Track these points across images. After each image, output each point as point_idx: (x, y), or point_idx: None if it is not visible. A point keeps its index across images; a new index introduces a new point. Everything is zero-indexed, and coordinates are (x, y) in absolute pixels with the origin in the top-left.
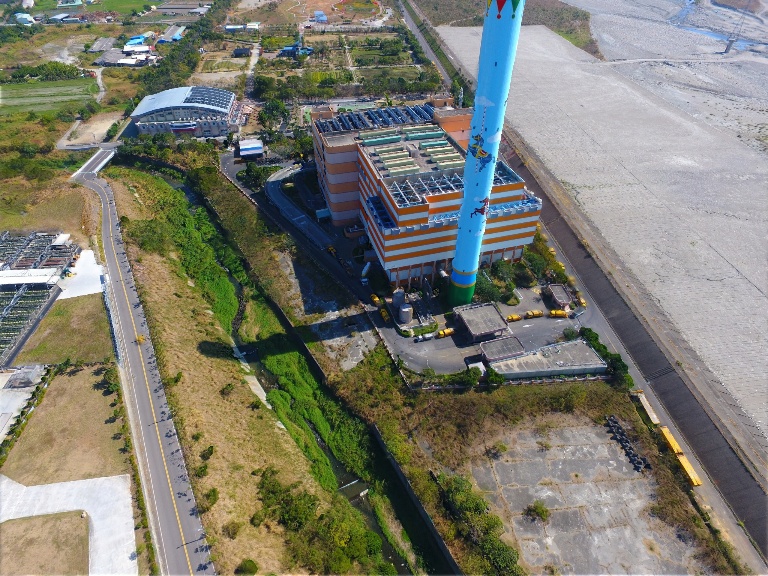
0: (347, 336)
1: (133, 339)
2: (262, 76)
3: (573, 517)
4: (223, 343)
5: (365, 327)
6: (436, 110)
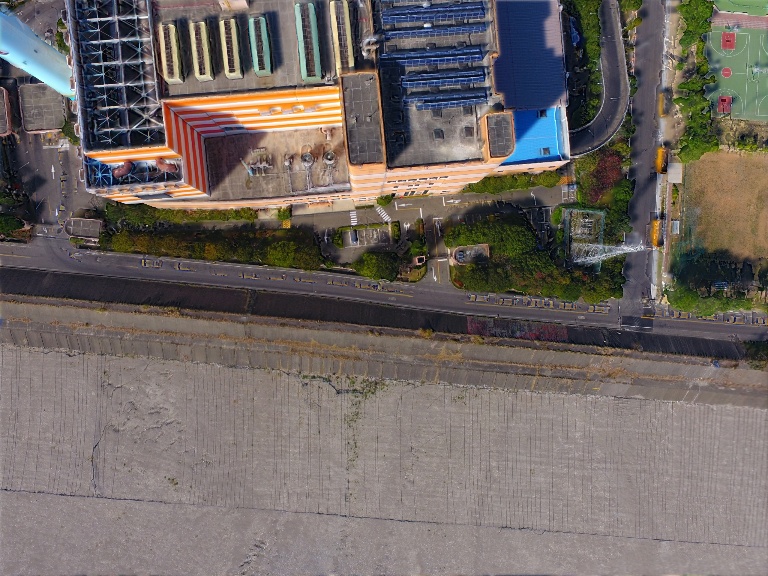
0: None
1: None
2: None
3: None
4: None
5: None
6: (460, 117)
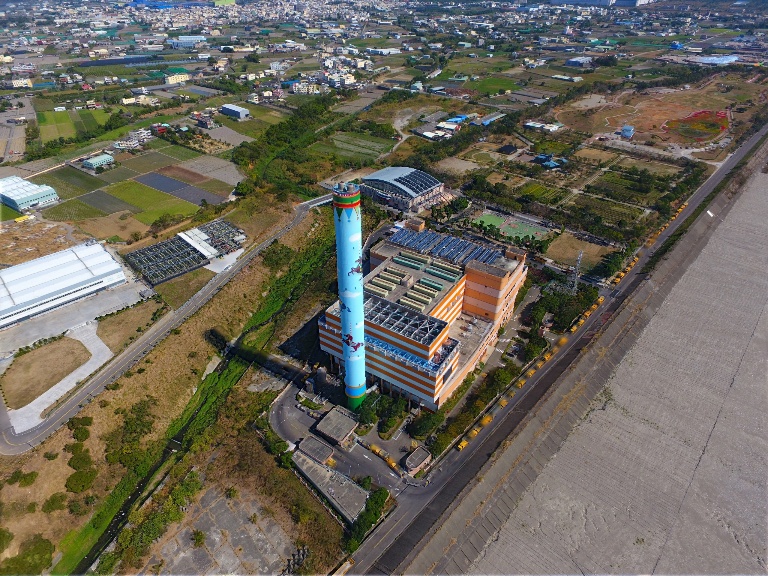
0: (275, 374)
1: (196, 304)
2: (481, 176)
3: (206, 561)
4: (230, 333)
5: (289, 377)
6: (500, 259)
